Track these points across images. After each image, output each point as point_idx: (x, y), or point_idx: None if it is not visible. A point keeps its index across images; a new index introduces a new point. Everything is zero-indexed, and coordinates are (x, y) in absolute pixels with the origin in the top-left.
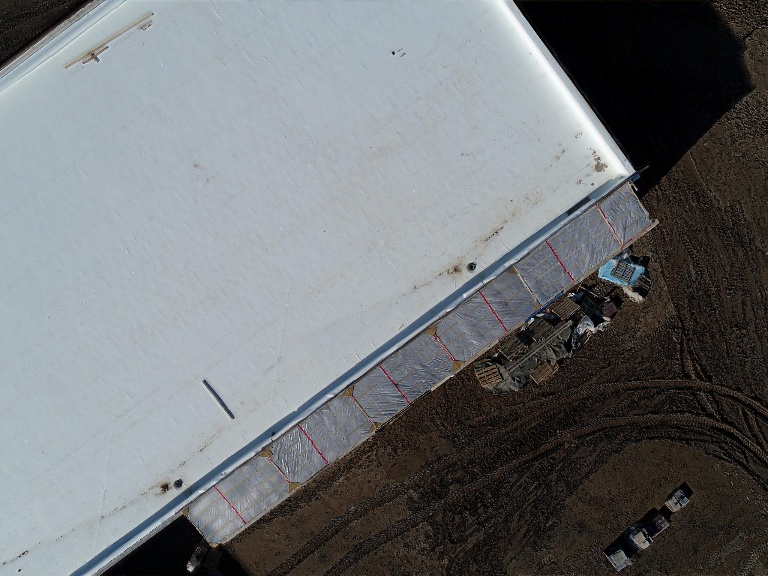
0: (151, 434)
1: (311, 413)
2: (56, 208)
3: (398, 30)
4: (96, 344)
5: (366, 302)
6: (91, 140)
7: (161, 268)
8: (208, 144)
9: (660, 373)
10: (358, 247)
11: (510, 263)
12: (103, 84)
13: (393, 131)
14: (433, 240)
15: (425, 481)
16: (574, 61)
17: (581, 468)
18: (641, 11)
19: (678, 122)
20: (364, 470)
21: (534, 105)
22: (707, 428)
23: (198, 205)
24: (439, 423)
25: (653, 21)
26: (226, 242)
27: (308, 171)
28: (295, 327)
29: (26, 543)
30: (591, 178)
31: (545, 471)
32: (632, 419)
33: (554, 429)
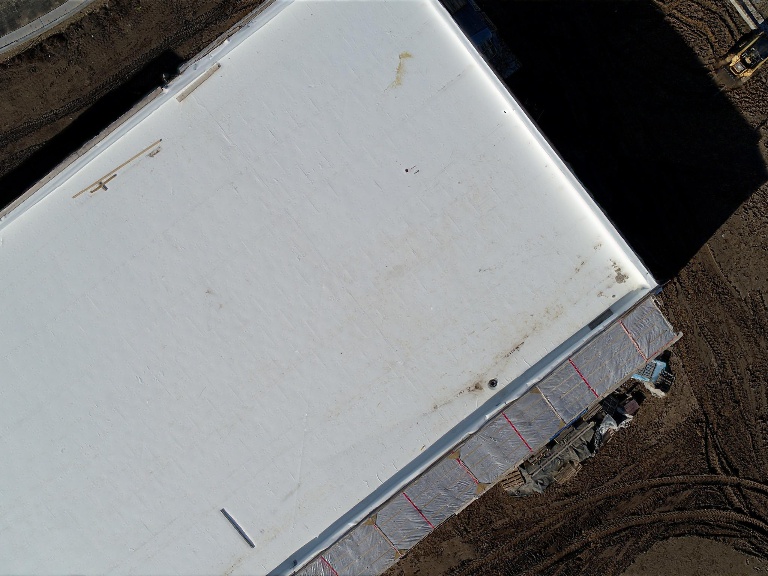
0: (169, 566)
1: (334, 542)
2: (67, 339)
3: (411, 147)
4: (111, 476)
5: (386, 423)
6: (101, 269)
7: (175, 396)
8: (220, 269)
9: (685, 468)
10: (376, 368)
11: (533, 382)
12: (112, 212)
13: (409, 249)
14: (453, 358)
15: None
16: (587, 156)
17: (608, 568)
18: (653, 103)
19: (695, 214)
20: None
21: (551, 218)
22: (735, 523)
23: (212, 331)
24: (461, 527)
25: (666, 113)
26: (241, 368)
27: (323, 293)
28: (314, 451)
29: None
30: (612, 290)
31: (571, 573)
32: (658, 516)
33: (579, 529)
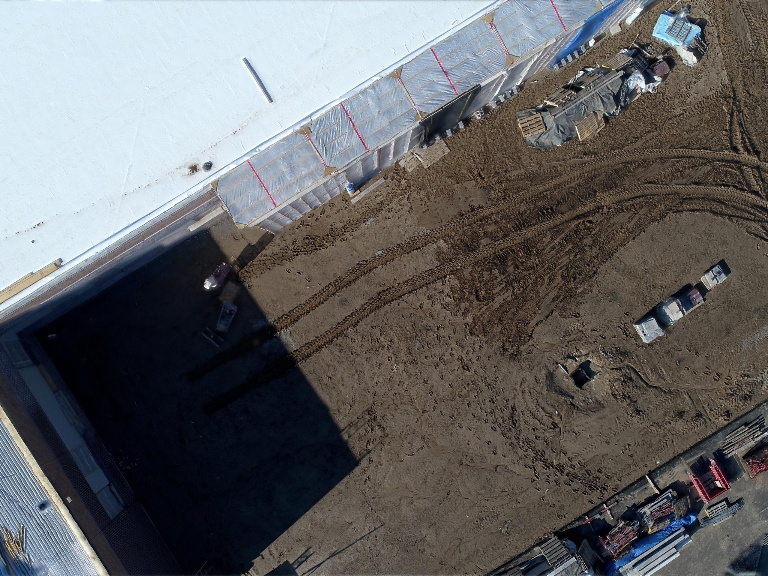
0: (184, 110)
1: None
2: None
3: None
4: (135, 8)
5: None
6: None
7: None
8: None
9: (707, 144)
10: None
11: None
12: None
13: None
14: None
15: (456, 232)
16: None
17: (618, 235)
18: None
19: None
20: (394, 214)
21: None
22: (750, 206)
23: None
24: (476, 172)
25: None
26: None
27: None
28: (344, 11)
29: (42, 213)
30: None
31: (581, 234)
32: (674, 189)
33: (594, 191)
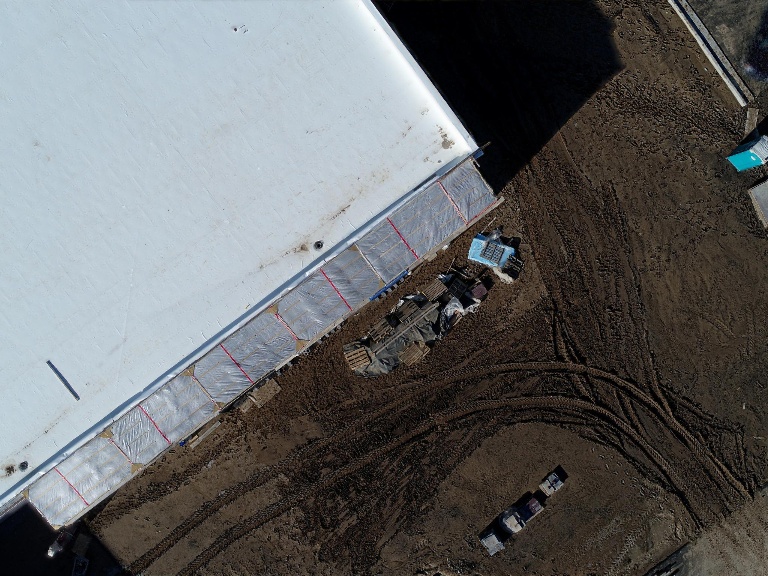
0: None
1: (152, 393)
2: None
3: (240, 6)
4: None
5: (212, 281)
6: None
7: (3, 248)
8: (49, 122)
9: (533, 355)
10: (203, 226)
11: (353, 241)
12: None
13: (236, 108)
14: (279, 218)
15: (296, 465)
16: (441, 41)
17: (454, 451)
18: None
19: (548, 102)
20: (233, 454)
21: (379, 82)
22: (581, 411)
23: (40, 184)
24: (309, 406)
25: (521, 0)
26: (69, 221)
27: (151, 149)
28: (140, 307)
29: None
30: (438, 155)
31: (417, 455)
32: (505, 402)
33: (426, 412)
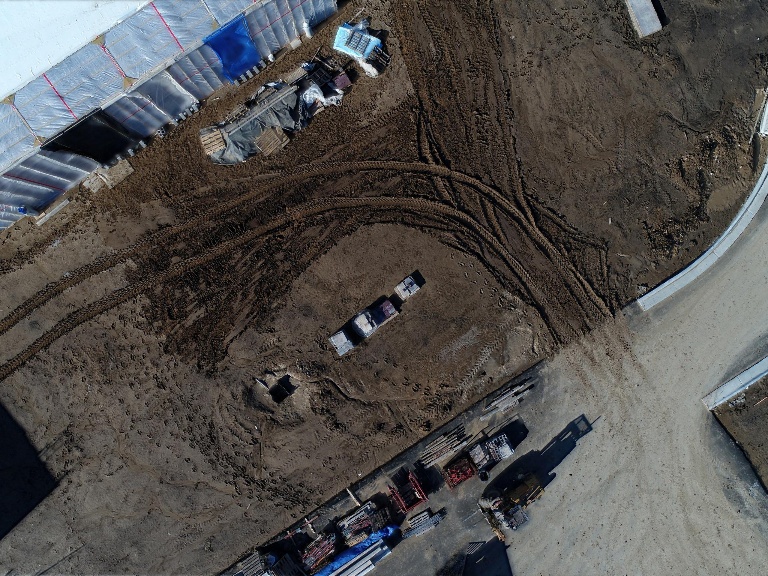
0: None
1: None
2: None
3: None
4: None
5: (44, 18)
6: None
7: None
8: None
9: (396, 155)
10: None
11: None
12: None
13: None
14: None
15: (145, 251)
16: None
17: (310, 249)
18: None
19: None
20: (81, 235)
21: None
22: (443, 215)
23: None
24: (162, 191)
25: None
26: None
27: None
28: None
29: None
30: None
31: (272, 249)
32: (365, 201)
33: (282, 205)
